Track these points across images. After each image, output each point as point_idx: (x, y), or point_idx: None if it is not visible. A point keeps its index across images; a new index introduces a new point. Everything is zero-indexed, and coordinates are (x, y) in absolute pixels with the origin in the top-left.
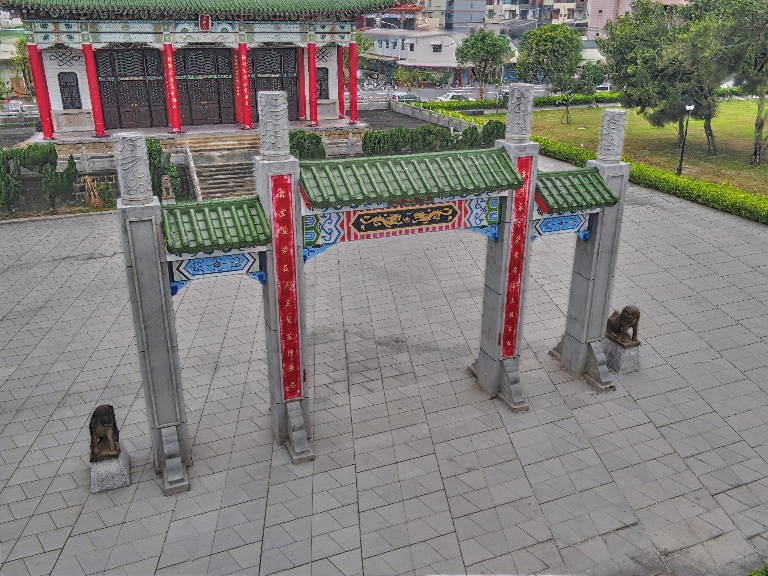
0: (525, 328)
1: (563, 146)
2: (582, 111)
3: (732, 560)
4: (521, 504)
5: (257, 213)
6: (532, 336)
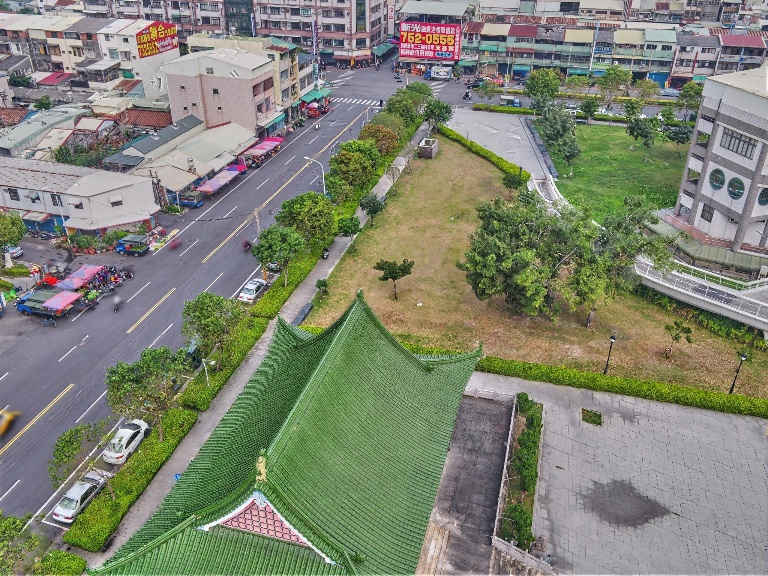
0: None
1: (498, 362)
2: (358, 263)
3: None
4: None
5: None
6: None
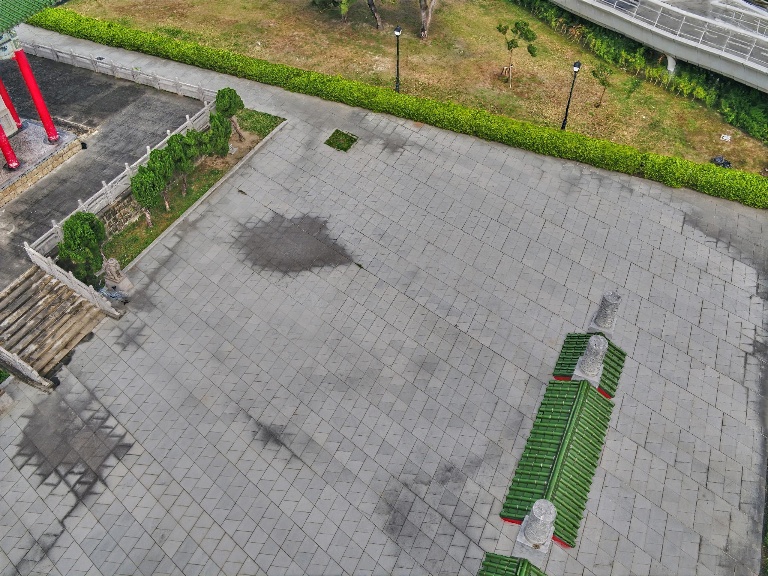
0: (500, 393)
1: (259, 64)
2: None
3: (747, 531)
4: (654, 570)
5: (537, 574)
6: (513, 400)
